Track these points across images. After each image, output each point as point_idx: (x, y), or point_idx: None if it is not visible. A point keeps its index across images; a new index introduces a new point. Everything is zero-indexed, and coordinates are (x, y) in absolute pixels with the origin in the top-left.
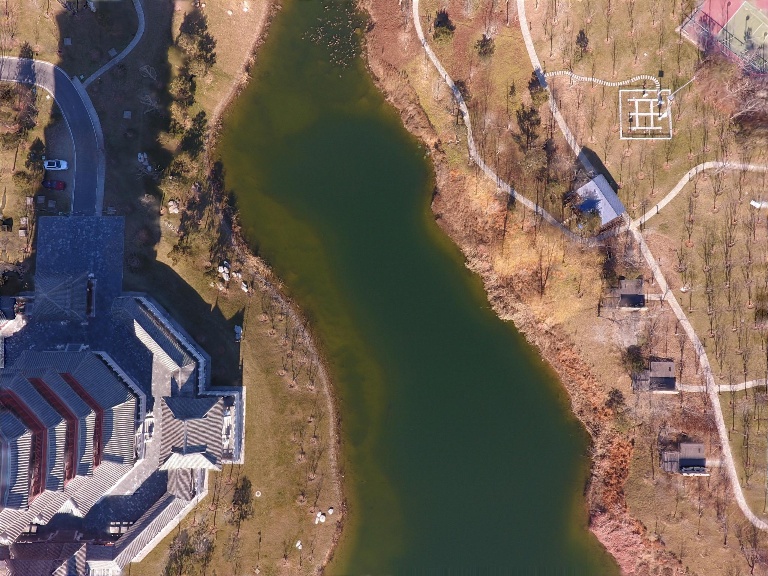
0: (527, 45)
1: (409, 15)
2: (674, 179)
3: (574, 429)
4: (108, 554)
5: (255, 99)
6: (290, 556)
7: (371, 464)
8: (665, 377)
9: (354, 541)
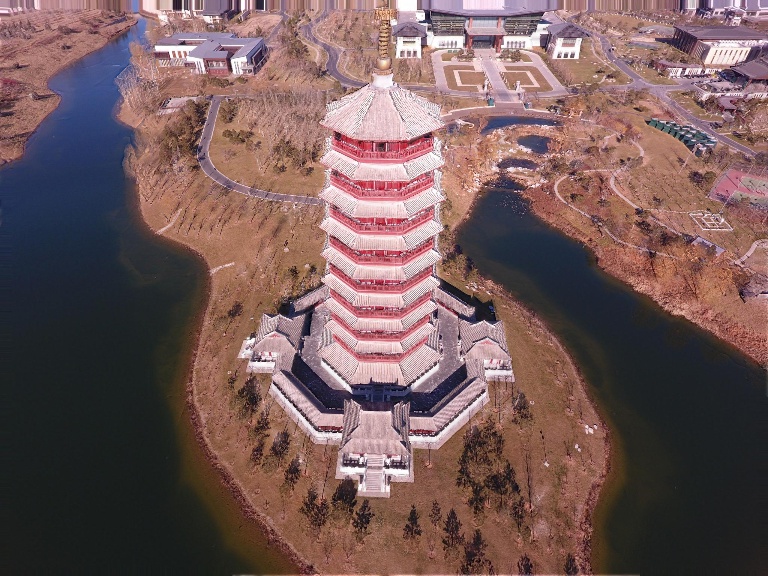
0: (627, 201)
1: (555, 196)
2: (747, 245)
3: None
4: (426, 415)
5: (473, 225)
6: (573, 455)
7: (615, 401)
8: None
9: (624, 458)
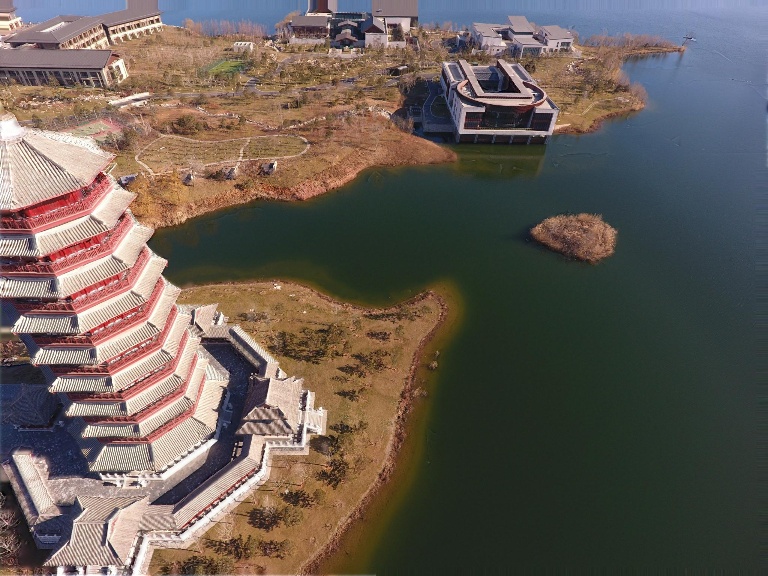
0: None
1: None
2: (137, 164)
3: (254, 204)
4: (263, 368)
5: None
6: None
7: (253, 273)
8: (230, 170)
9: None
